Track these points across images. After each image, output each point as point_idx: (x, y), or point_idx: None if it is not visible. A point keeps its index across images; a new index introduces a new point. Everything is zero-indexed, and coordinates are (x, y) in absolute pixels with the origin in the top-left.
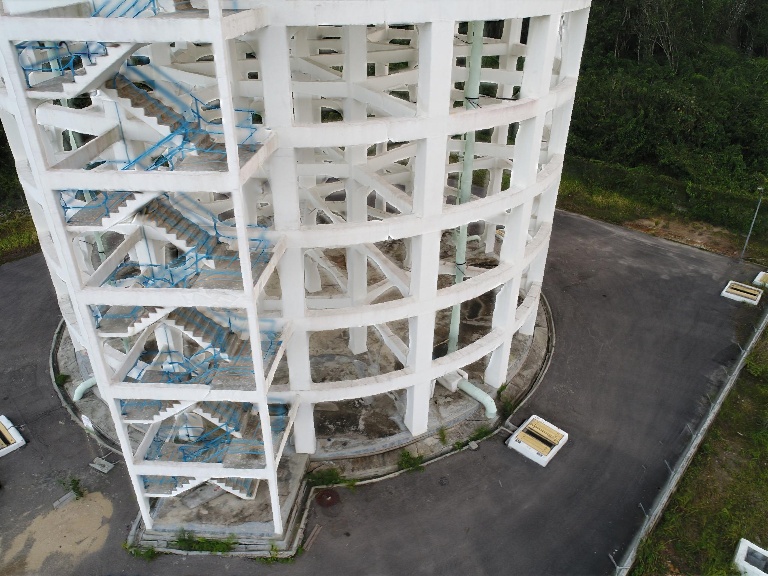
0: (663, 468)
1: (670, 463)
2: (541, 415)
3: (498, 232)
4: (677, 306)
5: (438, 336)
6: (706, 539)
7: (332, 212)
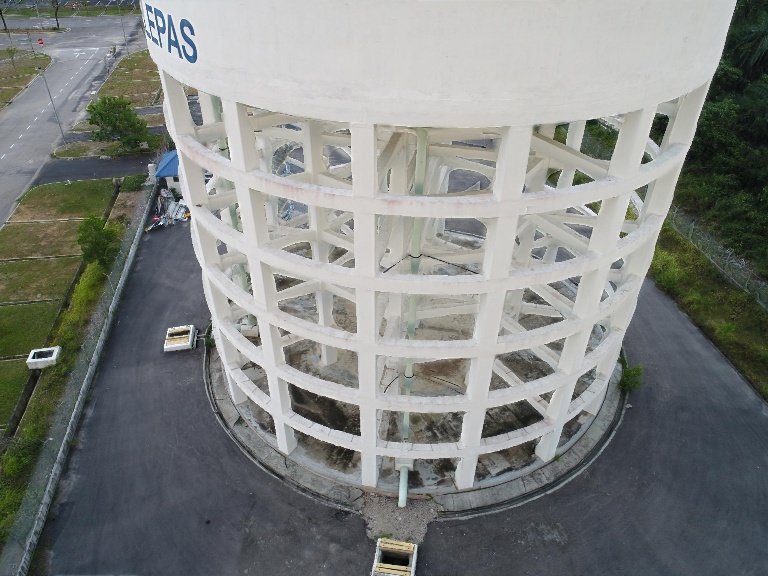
0: (103, 373)
1: (99, 379)
2: (189, 356)
3: (406, 544)
4: (122, 574)
5: (294, 353)
6: (74, 350)
7: (578, 415)
